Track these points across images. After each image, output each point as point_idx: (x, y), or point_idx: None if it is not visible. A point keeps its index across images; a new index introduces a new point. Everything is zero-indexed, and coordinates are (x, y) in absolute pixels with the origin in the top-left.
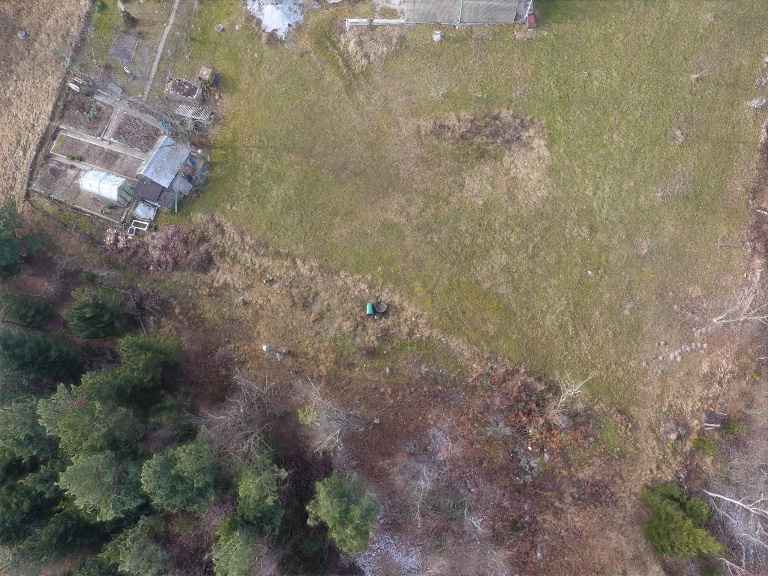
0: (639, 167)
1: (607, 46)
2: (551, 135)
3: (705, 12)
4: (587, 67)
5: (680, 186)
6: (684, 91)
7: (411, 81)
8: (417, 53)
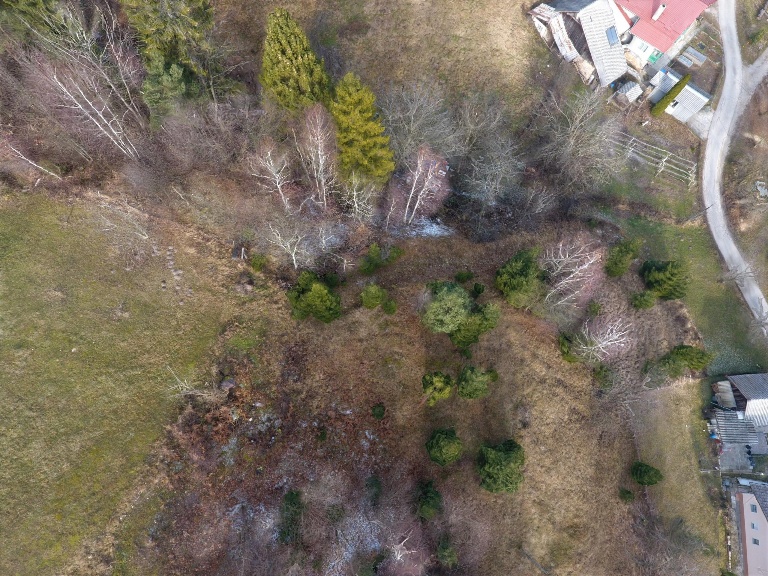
0: None
1: None
2: None
3: None
4: None
5: None
6: None
7: None
8: None
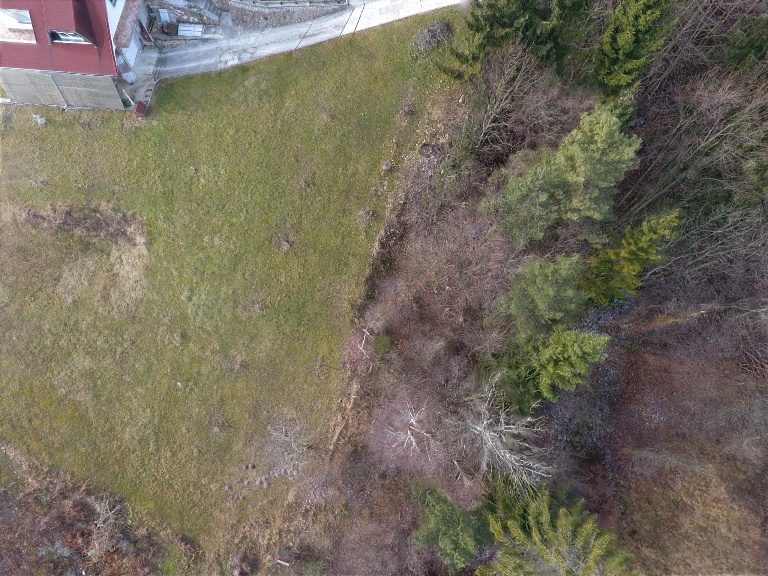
0: (239, 274)
1: (217, 141)
2: (151, 233)
3: (322, 112)
4: (195, 162)
5: (282, 297)
6: (293, 195)
7: (14, 165)
8: (22, 135)
